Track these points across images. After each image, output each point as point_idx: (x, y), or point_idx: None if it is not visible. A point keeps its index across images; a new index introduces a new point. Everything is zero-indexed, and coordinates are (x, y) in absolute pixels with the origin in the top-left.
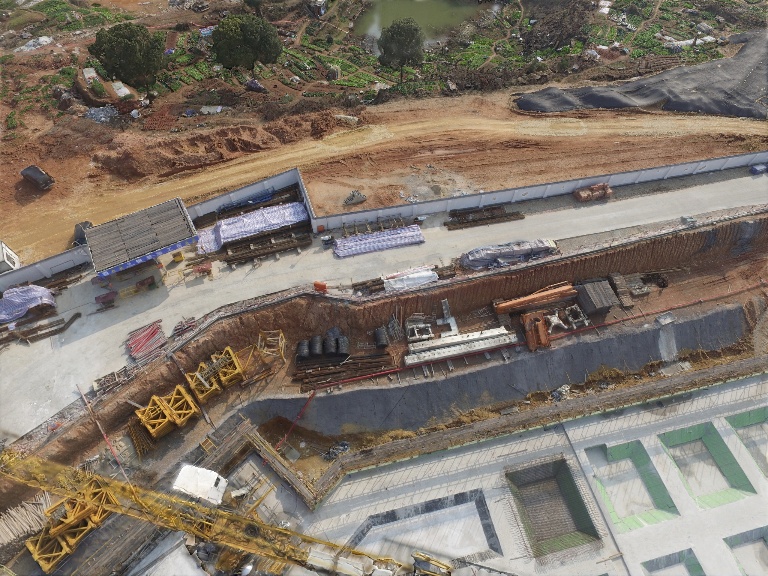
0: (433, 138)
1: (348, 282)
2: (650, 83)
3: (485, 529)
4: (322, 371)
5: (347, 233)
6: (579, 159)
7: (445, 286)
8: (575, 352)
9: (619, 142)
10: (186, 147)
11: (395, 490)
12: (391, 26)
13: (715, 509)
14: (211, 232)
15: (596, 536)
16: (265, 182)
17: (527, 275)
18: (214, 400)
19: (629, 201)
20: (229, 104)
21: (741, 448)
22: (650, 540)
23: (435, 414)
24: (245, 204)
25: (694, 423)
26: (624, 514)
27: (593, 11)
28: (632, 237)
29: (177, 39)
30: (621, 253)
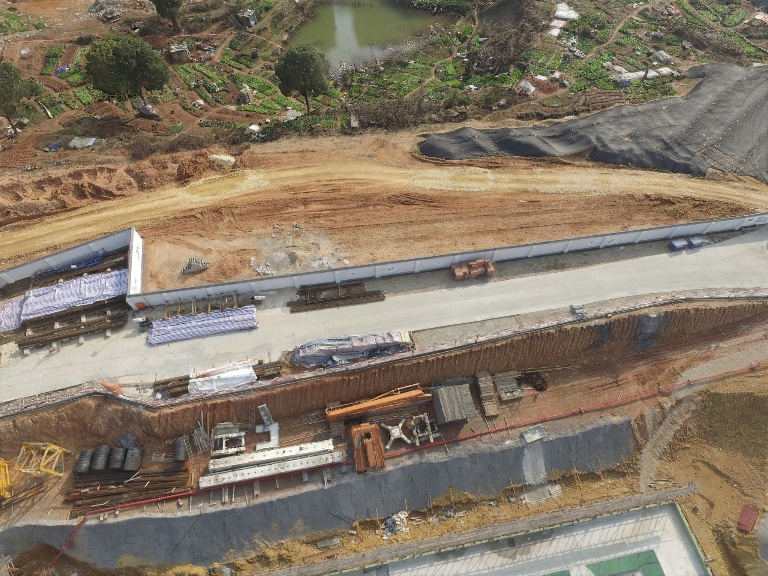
0: (312, 189)
1: (151, 379)
2: (578, 127)
3: None
4: (100, 491)
5: (168, 313)
6: (471, 223)
7: (264, 389)
8: (416, 473)
9: (526, 201)
10: (29, 191)
11: None
12: (285, 53)
13: None
14: (18, 304)
15: None
16: (91, 244)
17: (369, 375)
18: None
19: (514, 281)
20: (107, 135)
21: None
22: None
23: (234, 547)
24: (66, 269)
25: (547, 571)
26: None
27: (542, 32)
28: (505, 330)
29: (75, 54)
30: (489, 350)
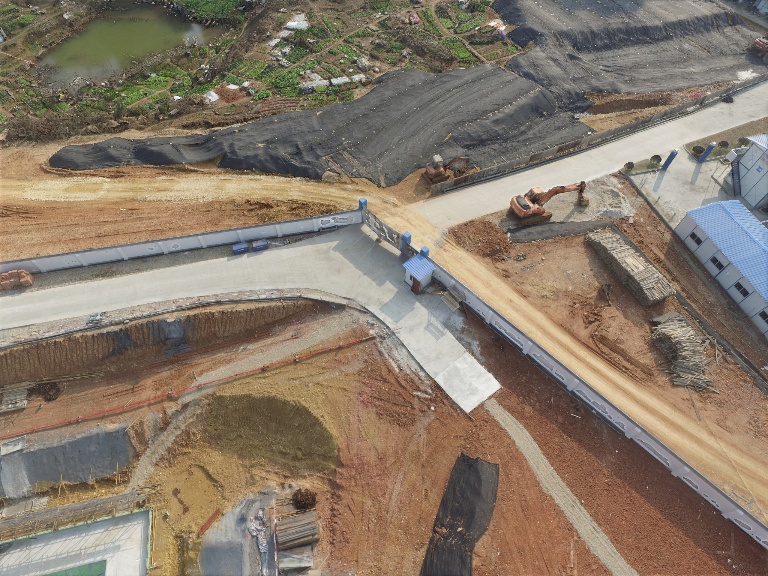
0: None
1: None
2: (220, 134)
3: None
4: None
5: None
6: (49, 233)
7: None
8: None
9: (126, 209)
10: None
11: None
12: None
13: None
14: None
15: None
16: None
17: None
18: None
19: (51, 291)
20: None
21: None
22: None
23: None
24: None
25: None
26: None
27: (262, 43)
28: None
29: None
30: None
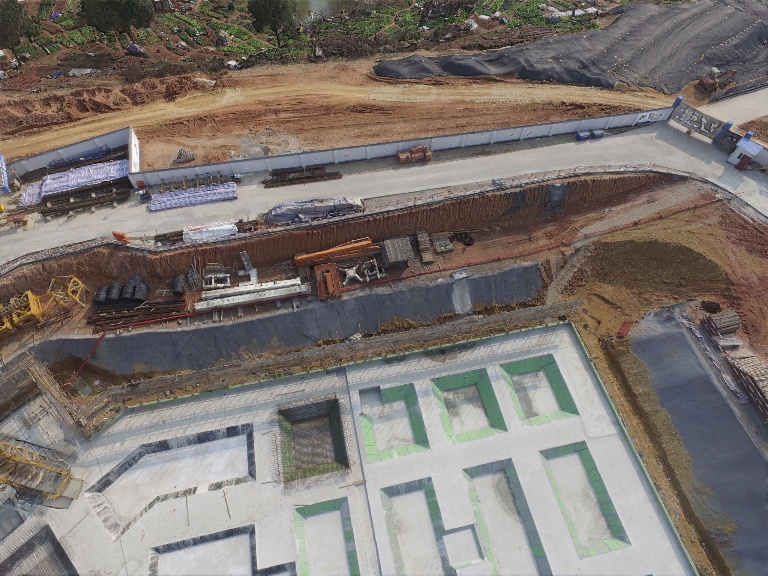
0: (282, 102)
1: (152, 234)
2: (510, 52)
3: (249, 458)
4: (116, 315)
5: (164, 189)
6: (415, 124)
7: (244, 239)
8: (367, 303)
9: (462, 108)
10: (38, 107)
11: (172, 423)
12: None
13: (464, 444)
14: (37, 186)
15: (347, 465)
16: (96, 140)
17: (329, 230)
18: (9, 339)
19: (448, 164)
20: (101, 67)
21: (506, 392)
22: (395, 469)
23: (223, 356)
24: (76, 161)
25: (469, 369)
26: (383, 448)
27: None
28: (438, 197)
29: (67, 3)
30: (426, 212)
